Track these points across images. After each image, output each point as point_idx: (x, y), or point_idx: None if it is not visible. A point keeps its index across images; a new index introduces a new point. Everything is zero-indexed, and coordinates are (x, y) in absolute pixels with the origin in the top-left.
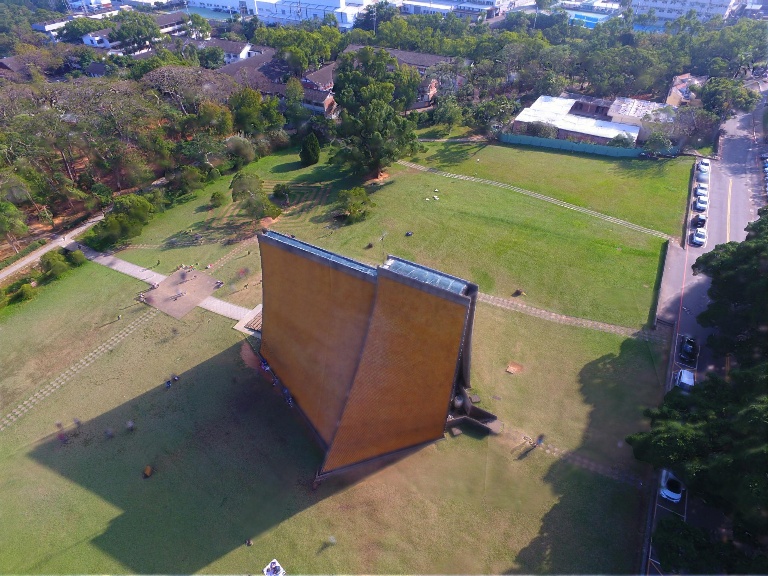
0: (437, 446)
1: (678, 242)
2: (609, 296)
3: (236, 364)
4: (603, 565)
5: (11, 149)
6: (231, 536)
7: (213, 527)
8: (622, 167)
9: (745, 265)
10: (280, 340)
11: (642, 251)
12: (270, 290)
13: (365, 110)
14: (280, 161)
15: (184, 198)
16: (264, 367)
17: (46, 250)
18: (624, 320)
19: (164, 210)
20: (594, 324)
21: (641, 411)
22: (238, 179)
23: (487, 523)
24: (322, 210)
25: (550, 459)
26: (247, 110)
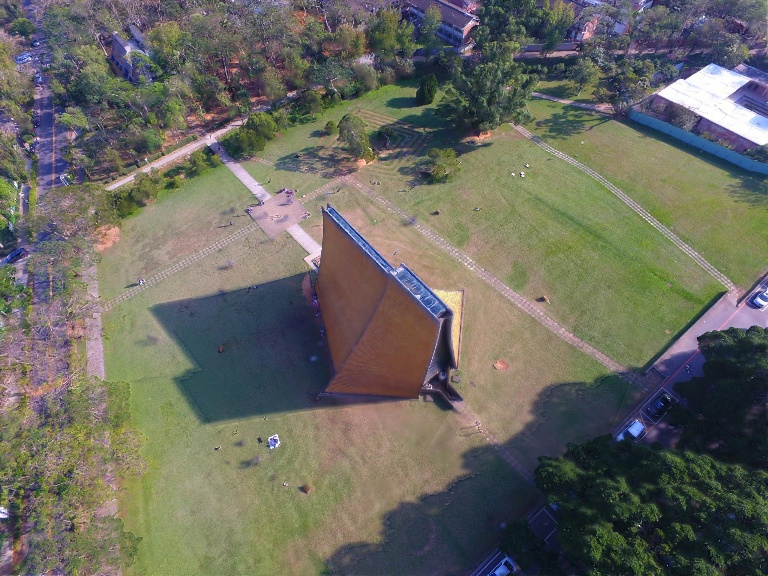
0: (410, 403)
1: (738, 296)
2: (625, 330)
3: (296, 290)
4: (479, 528)
5: (183, 52)
6: (257, 410)
7: (248, 400)
8: (745, 186)
9: (736, 358)
10: (327, 286)
11: (691, 294)
12: (326, 248)
13: (479, 71)
14: (398, 93)
15: (306, 118)
16: (314, 300)
17: (196, 145)
18: (622, 357)
19: (287, 128)
20: (593, 351)
21: (581, 439)
22: (345, 121)
23: (418, 469)
24: (413, 161)
25: (486, 445)
26: (380, 36)
